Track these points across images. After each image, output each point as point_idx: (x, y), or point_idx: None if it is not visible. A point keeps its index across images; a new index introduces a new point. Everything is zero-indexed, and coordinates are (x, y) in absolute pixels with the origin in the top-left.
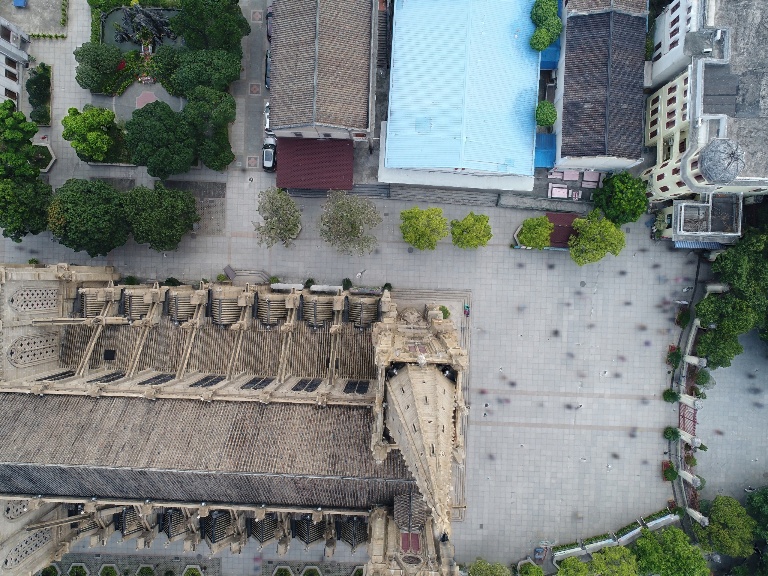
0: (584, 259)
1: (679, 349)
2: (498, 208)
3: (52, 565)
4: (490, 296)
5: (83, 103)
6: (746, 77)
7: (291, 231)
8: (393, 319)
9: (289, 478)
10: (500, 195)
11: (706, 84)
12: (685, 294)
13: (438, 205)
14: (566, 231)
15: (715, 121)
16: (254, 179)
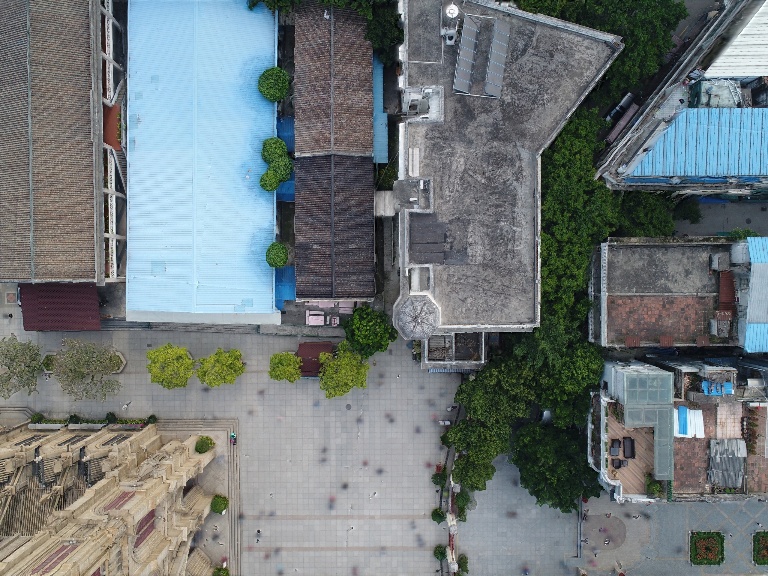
0: (331, 393)
1: (445, 469)
2: (261, 335)
3: None
4: (257, 423)
5: None
6: (453, 224)
7: (30, 380)
8: (102, 486)
9: None
10: (257, 325)
11: (414, 232)
12: (450, 413)
13: (201, 334)
14: (317, 363)
15: (425, 269)
16: (14, 315)
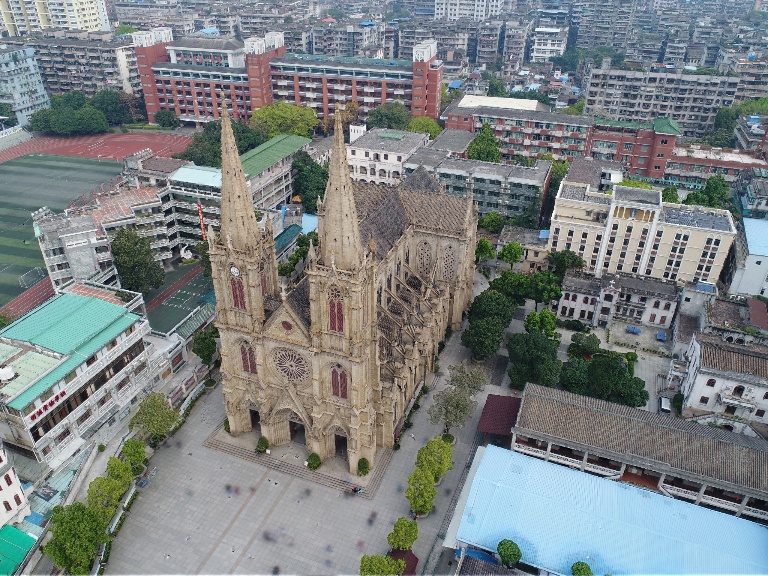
0: None
1: None
2: None
3: None
4: (362, 512)
5: (565, 341)
6: None
7: None
8: None
9: None
10: None
11: None
12: None
13: (451, 498)
14: None
15: None
16: None
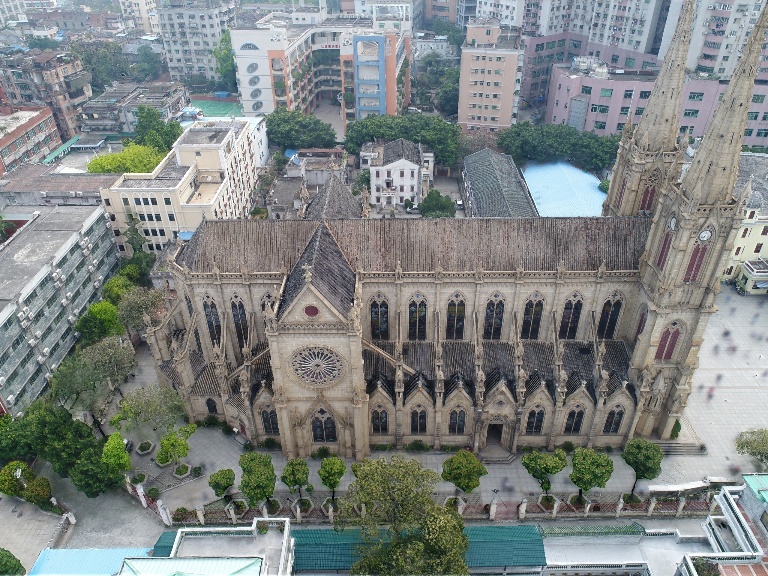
0: None
1: None
2: None
3: (306, 499)
4: None
5: None
6: None
7: None
8: None
9: (583, 220)
10: None
11: None
12: None
13: None
14: None
15: None
16: None
